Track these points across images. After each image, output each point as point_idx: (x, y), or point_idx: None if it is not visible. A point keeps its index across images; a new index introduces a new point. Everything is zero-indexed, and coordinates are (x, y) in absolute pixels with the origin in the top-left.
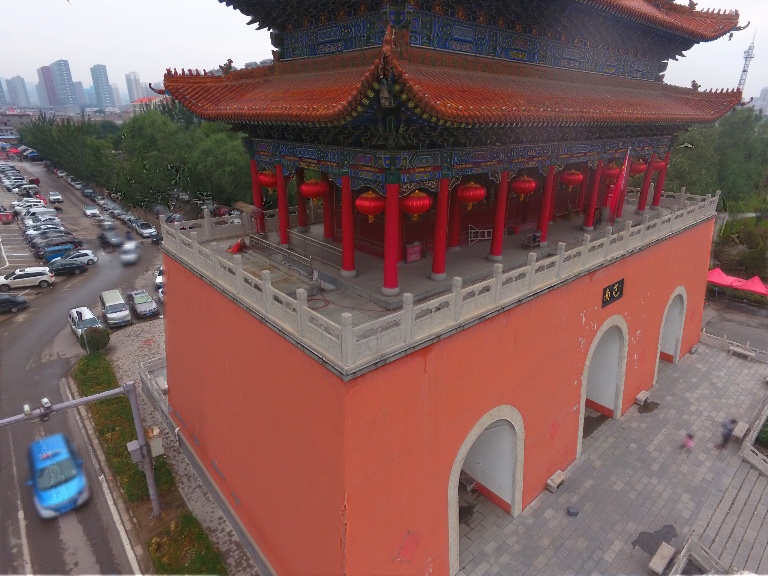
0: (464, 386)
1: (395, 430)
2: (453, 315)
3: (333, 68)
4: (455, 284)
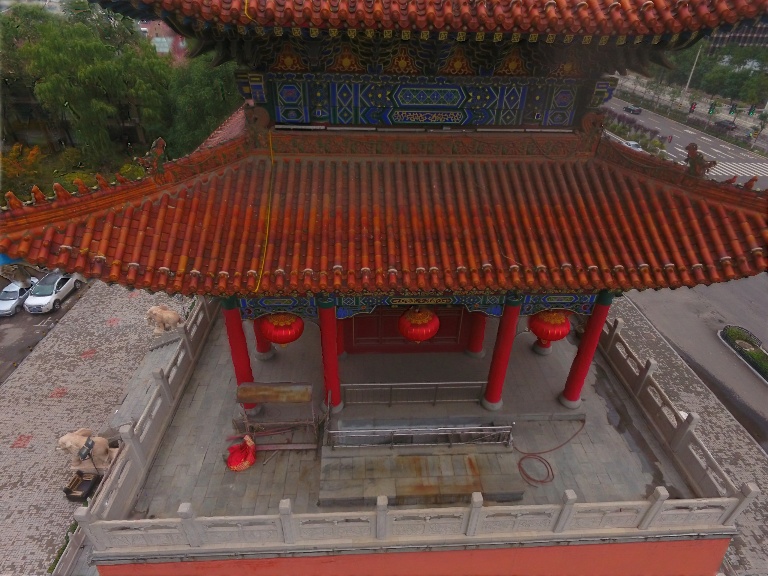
0: None
1: None
2: None
3: (452, 153)
4: (653, 368)
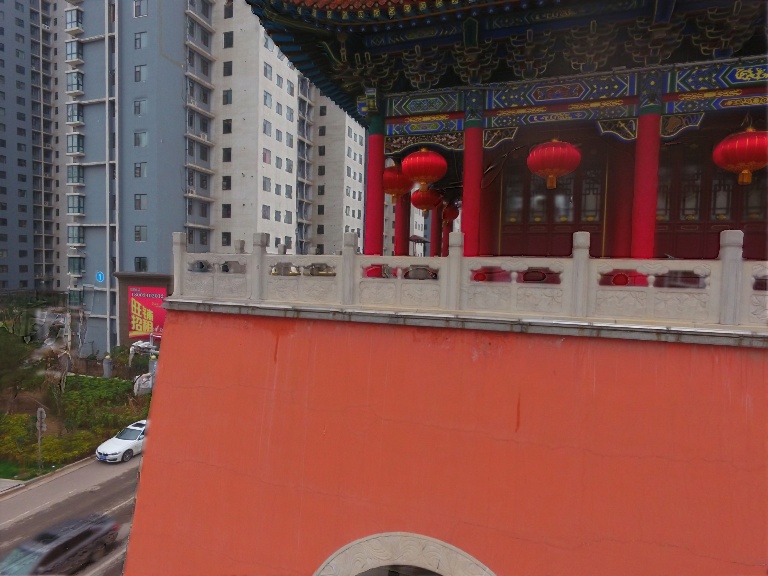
0: (353, 433)
1: (217, 420)
2: (341, 292)
3: None
4: None
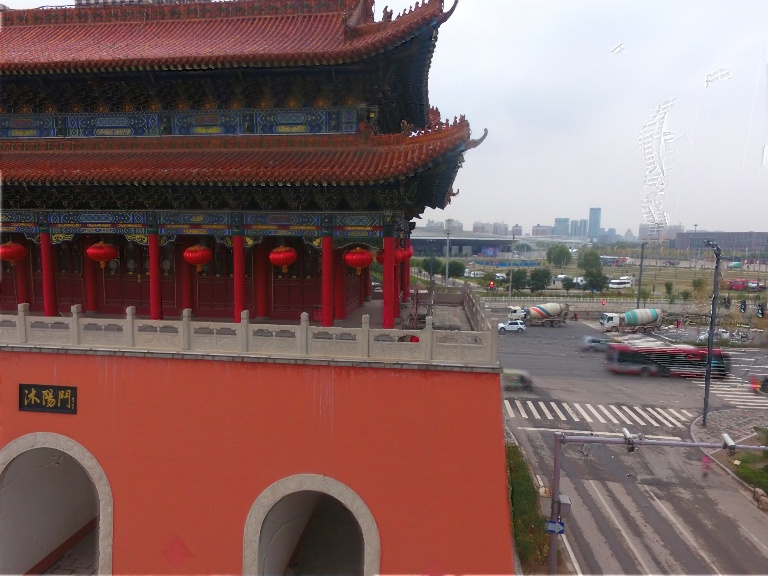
0: None
1: None
2: None
3: None
4: None
